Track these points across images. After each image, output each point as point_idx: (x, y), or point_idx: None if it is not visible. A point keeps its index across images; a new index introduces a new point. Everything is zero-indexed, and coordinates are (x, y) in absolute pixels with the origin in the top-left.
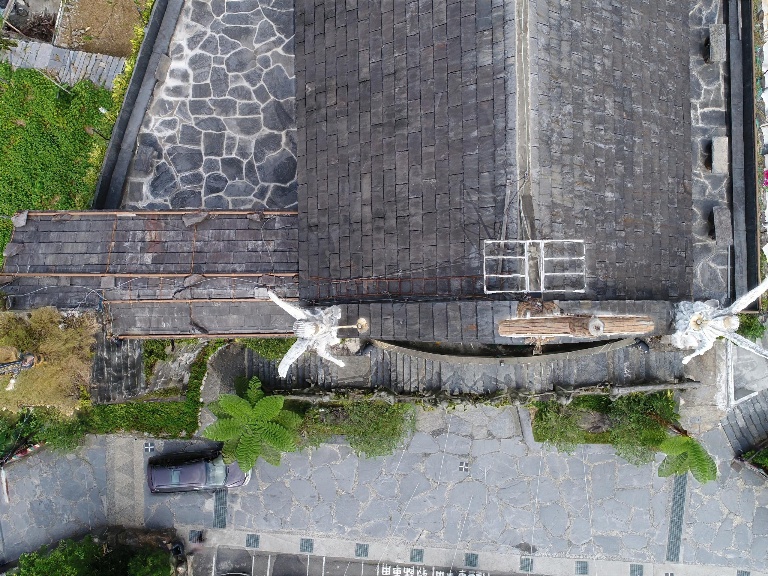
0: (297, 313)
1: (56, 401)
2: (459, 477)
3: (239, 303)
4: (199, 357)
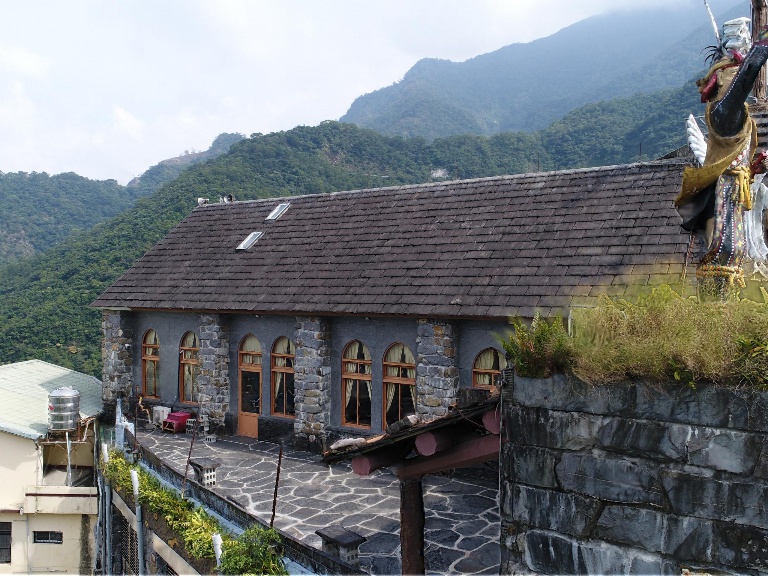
0: None
1: None
2: None
3: None
4: None
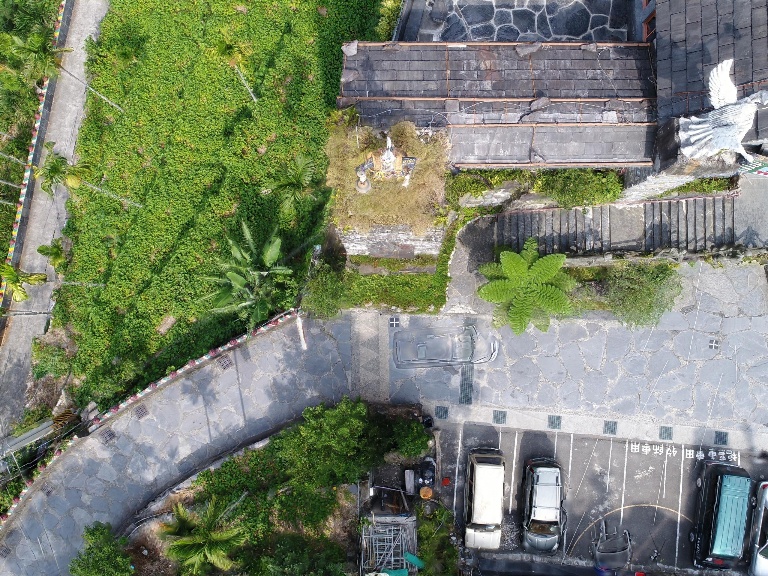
0: (731, 94)
1: (414, 217)
2: (709, 355)
3: (584, 128)
4: (448, 231)
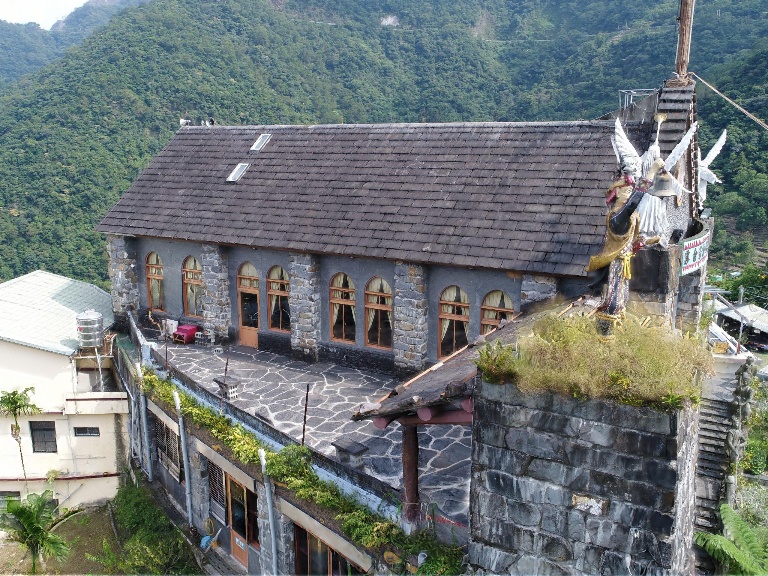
0: None
1: None
2: None
3: None
4: None
